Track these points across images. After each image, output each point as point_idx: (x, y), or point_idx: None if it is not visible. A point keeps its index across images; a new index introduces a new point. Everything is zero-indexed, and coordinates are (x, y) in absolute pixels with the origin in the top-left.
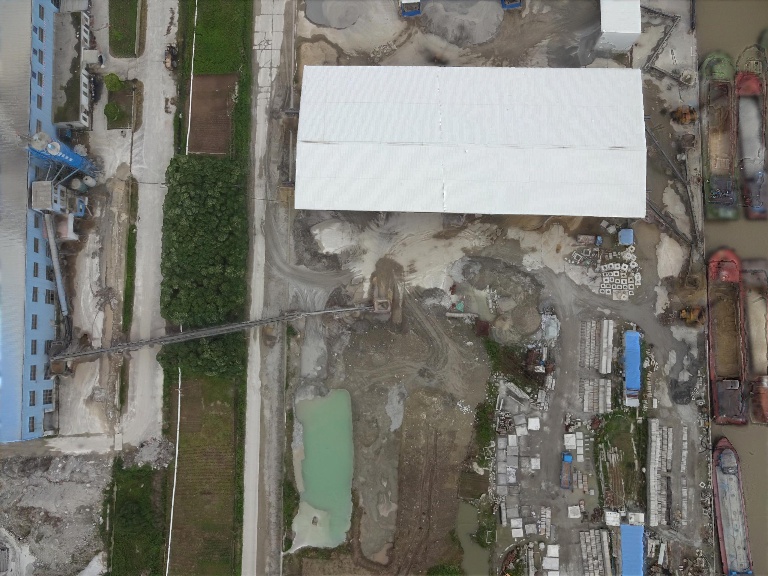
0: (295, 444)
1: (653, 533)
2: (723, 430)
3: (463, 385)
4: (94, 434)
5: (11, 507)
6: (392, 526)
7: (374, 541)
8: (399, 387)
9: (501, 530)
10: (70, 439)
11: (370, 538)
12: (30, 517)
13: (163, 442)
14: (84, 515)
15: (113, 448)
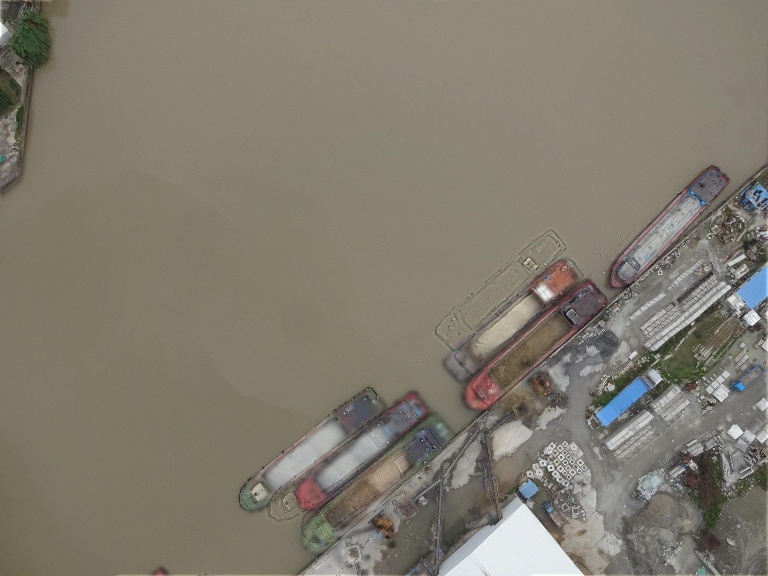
0: None
1: (728, 278)
2: (599, 286)
3: None
4: None
5: None
6: None
7: None
8: None
9: None
10: None
11: None
12: None
13: None
14: None
15: None
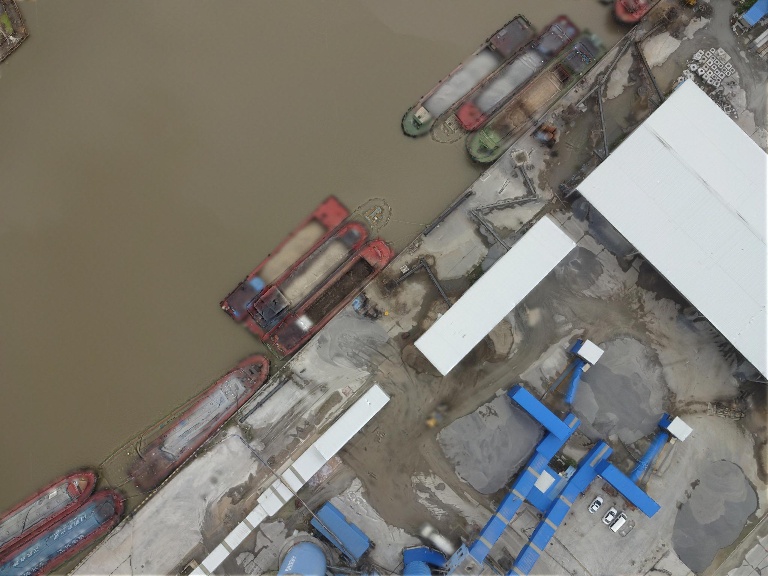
0: None
1: None
2: None
3: None
4: None
5: None
6: None
7: None
8: None
9: None
10: None
11: None
12: None
13: None
14: None
15: None
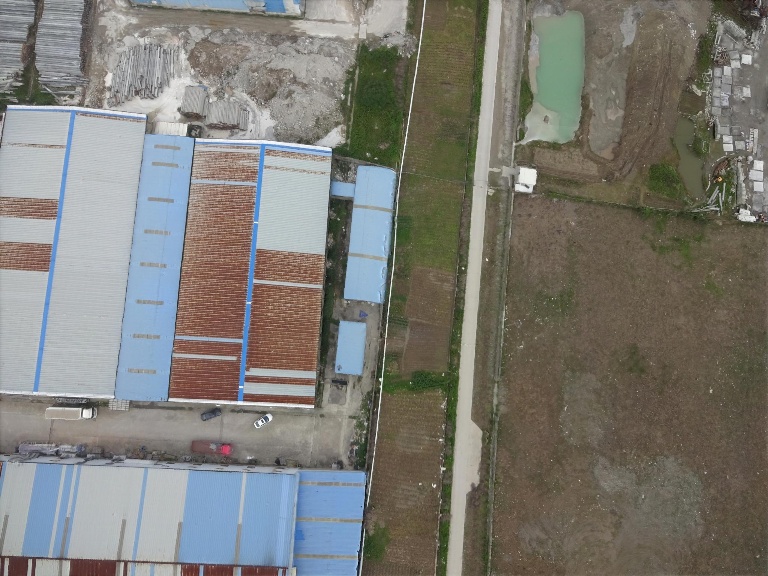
0: (531, 52)
1: None
2: None
3: (693, 11)
4: (339, 21)
5: (261, 66)
6: (618, 128)
7: (602, 139)
8: (634, 9)
9: (714, 144)
10: (316, 23)
11: (598, 136)
12: (281, 76)
13: (407, 36)
14: (328, 88)
15: (358, 36)
